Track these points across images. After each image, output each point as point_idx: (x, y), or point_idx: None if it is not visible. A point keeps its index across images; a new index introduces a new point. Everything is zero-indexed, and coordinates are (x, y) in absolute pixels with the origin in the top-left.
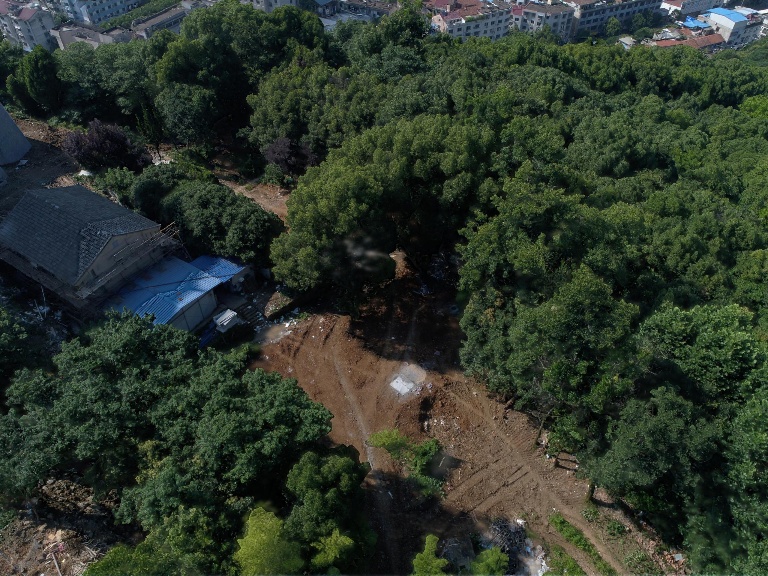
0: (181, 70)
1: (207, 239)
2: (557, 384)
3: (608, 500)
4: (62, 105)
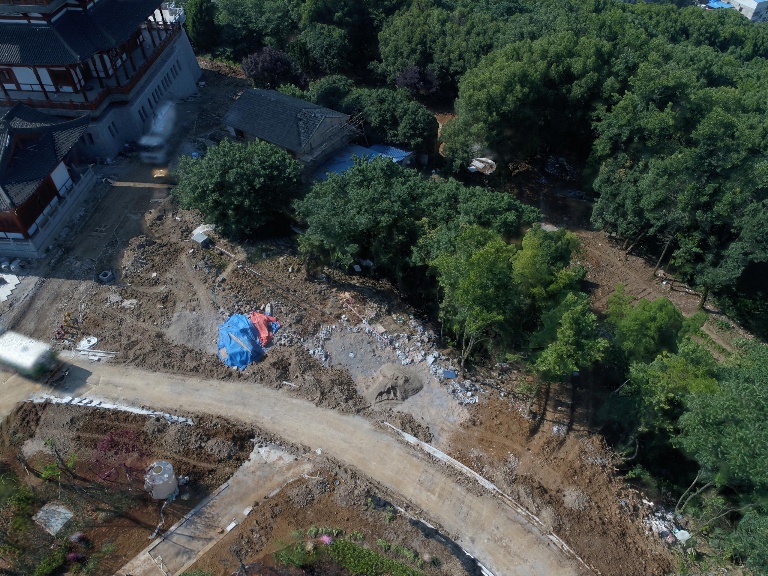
0: (320, 13)
1: (381, 130)
2: (690, 202)
3: (714, 310)
4: (211, 45)
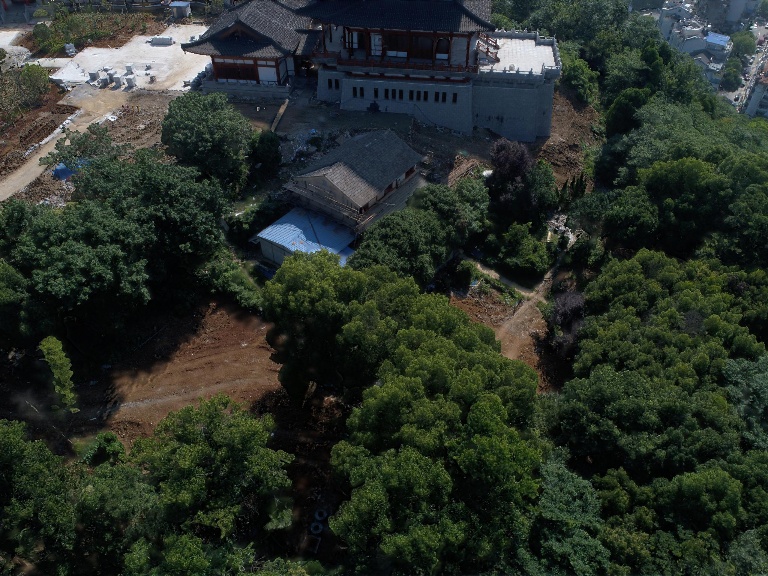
0: (667, 185)
1: None
2: None
3: None
4: None
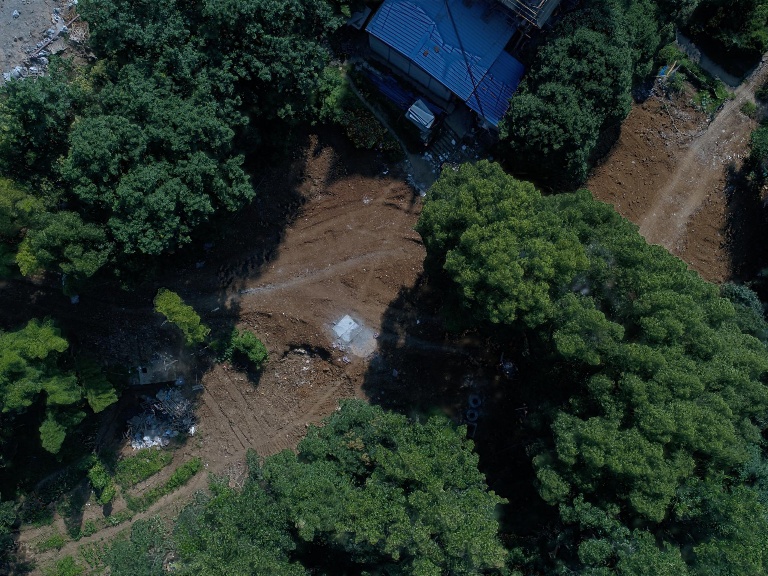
0: None
1: None
2: None
3: None
4: None
